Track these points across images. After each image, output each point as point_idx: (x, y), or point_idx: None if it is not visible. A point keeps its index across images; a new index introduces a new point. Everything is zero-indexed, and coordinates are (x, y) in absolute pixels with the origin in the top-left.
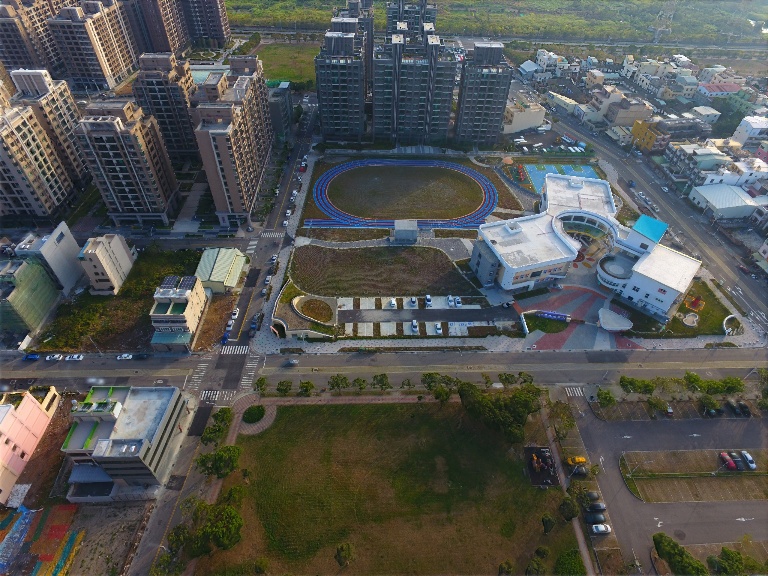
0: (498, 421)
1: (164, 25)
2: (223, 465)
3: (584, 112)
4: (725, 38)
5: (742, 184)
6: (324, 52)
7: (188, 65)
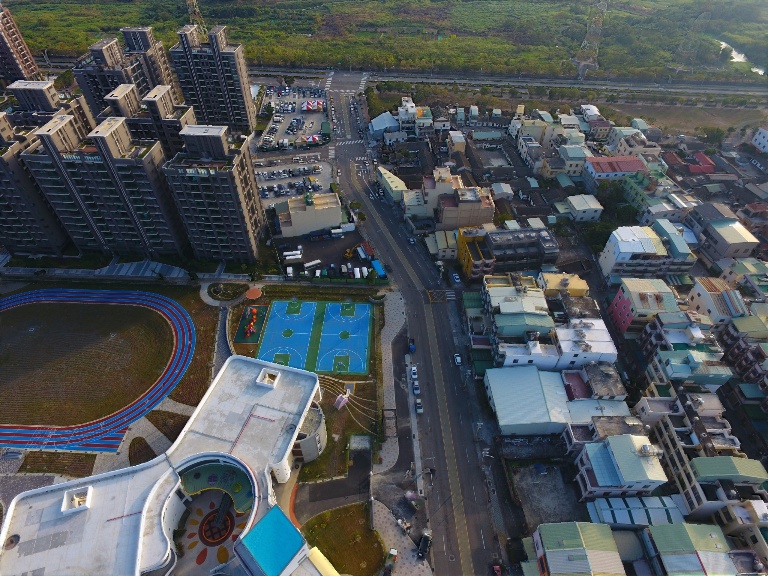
0: None
1: None
2: None
3: (404, 205)
4: (670, 74)
5: None
6: None
7: None
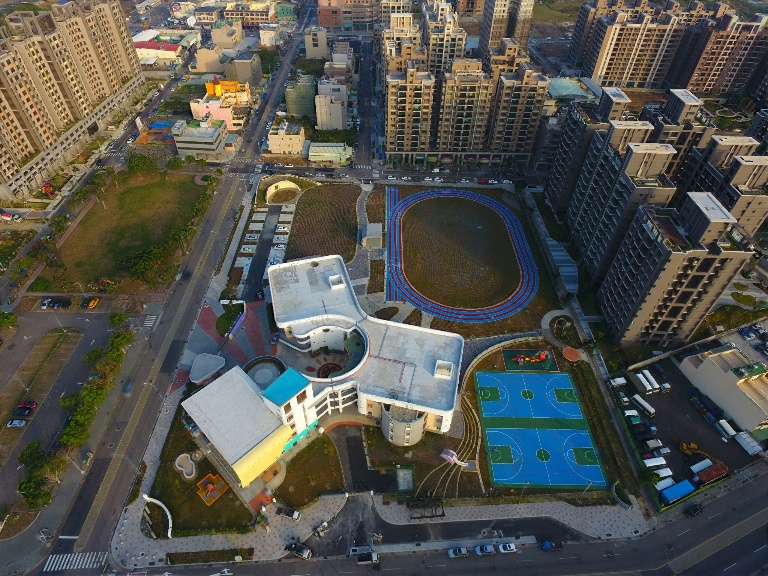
0: None
1: (699, 62)
2: None
3: None
4: None
5: None
6: None
7: None
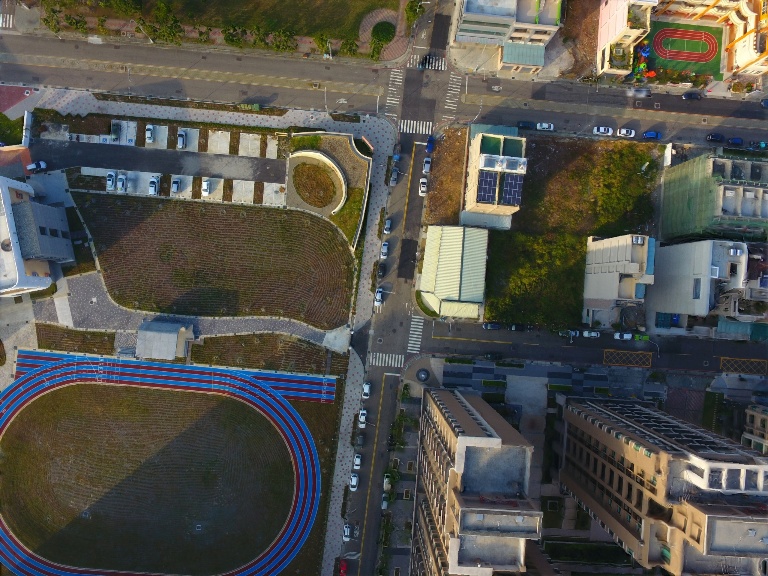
0: None
1: None
2: None
3: None
4: None
5: None
6: None
7: None
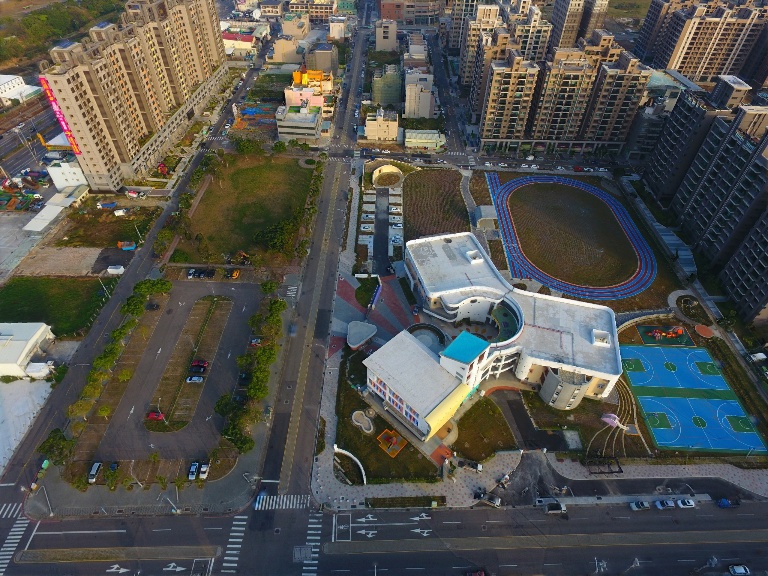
0: None
1: None
2: None
3: None
4: None
5: None
6: None
7: None
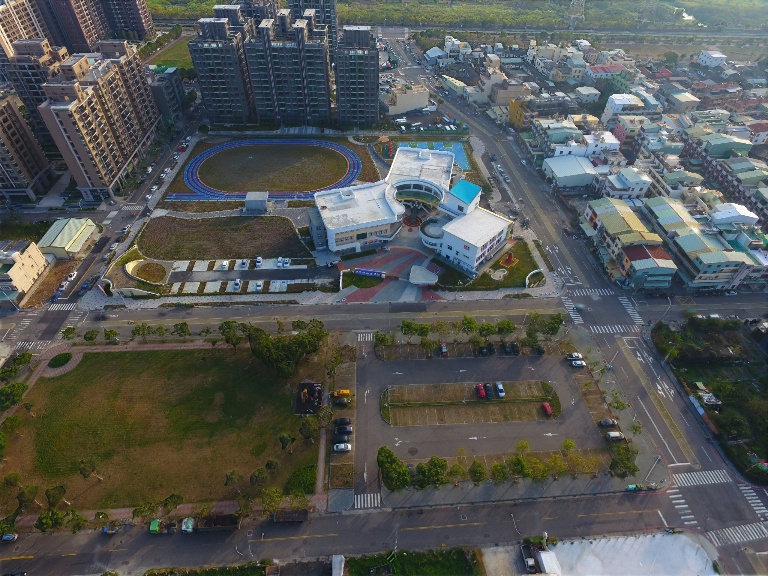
0: (272, 359)
1: (77, 17)
2: (5, 399)
3: (469, 93)
4: None
5: (590, 155)
6: (200, 37)
7: (65, 51)
